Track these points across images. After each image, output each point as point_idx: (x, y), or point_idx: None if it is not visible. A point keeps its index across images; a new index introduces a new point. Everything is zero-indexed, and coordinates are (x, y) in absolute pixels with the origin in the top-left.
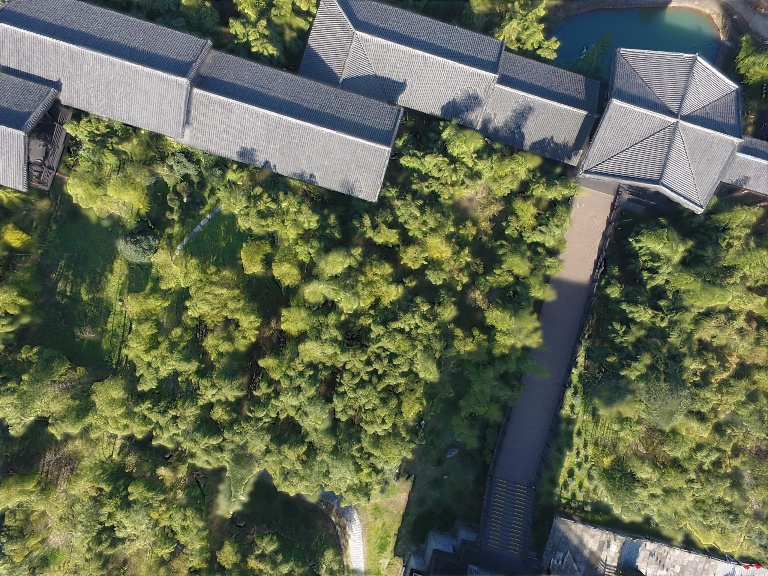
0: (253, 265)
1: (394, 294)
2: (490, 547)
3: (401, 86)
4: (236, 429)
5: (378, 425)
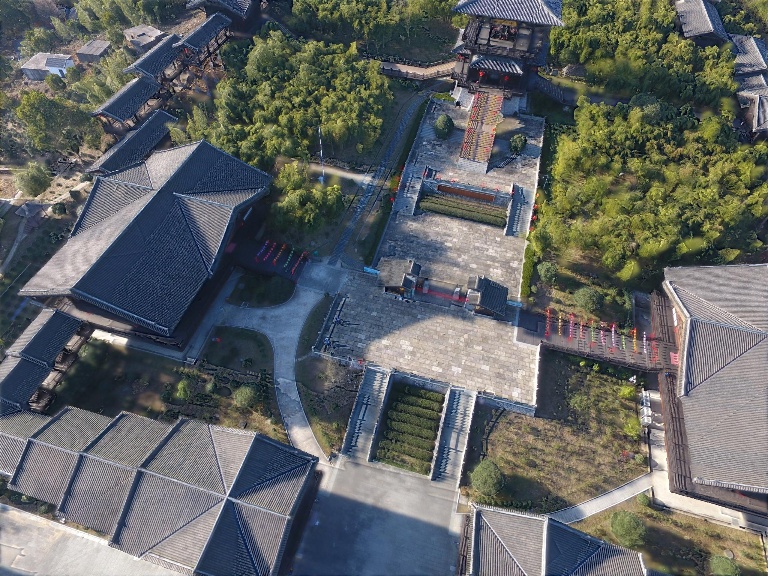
0: (643, 8)
1: None
2: (538, 77)
3: (738, 52)
4: None
5: None
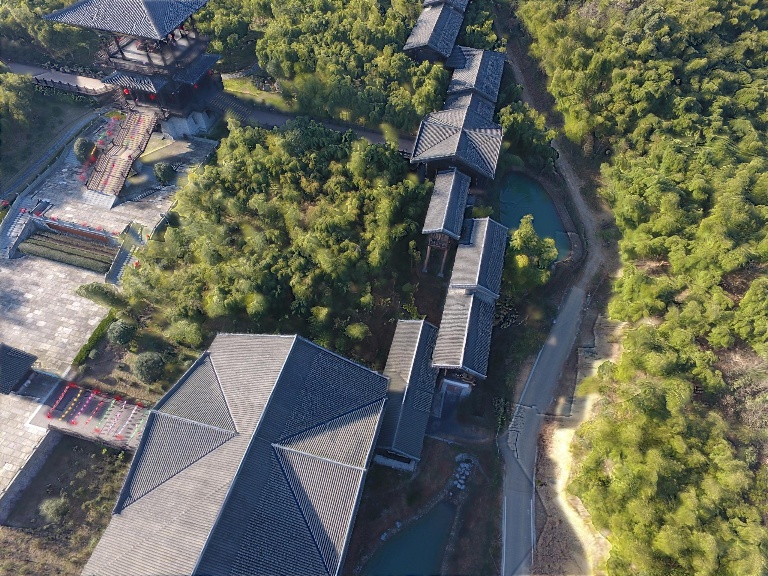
0: (372, 16)
1: (359, 53)
2: (217, 94)
3: None
4: (302, 4)
5: (296, 45)
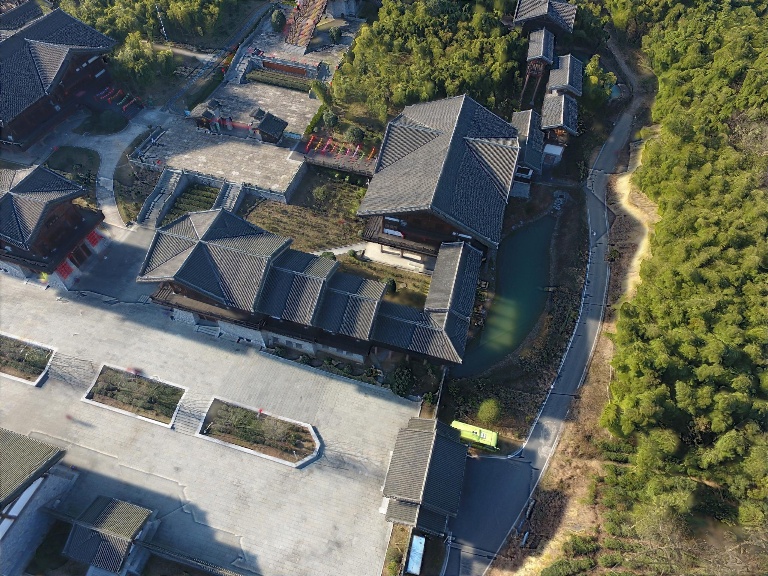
0: None
1: None
2: None
3: None
4: None
5: None
